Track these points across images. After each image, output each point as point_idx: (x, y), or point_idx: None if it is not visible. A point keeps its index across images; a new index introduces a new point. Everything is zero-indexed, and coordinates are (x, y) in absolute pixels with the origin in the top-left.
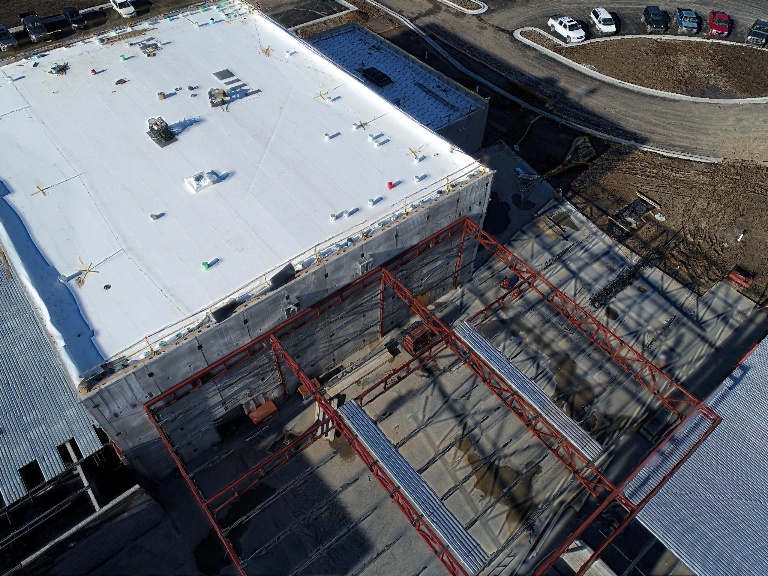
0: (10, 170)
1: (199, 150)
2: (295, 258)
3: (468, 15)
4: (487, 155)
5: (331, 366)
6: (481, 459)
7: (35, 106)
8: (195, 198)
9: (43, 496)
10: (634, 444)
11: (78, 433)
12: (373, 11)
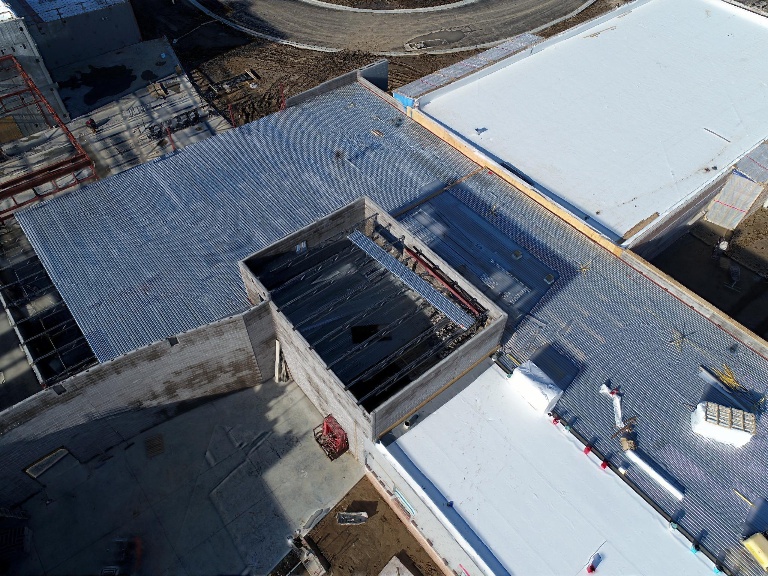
0: None
1: None
2: None
3: None
4: (145, 45)
5: None
6: None
7: None
8: None
9: None
10: None
11: None
12: None
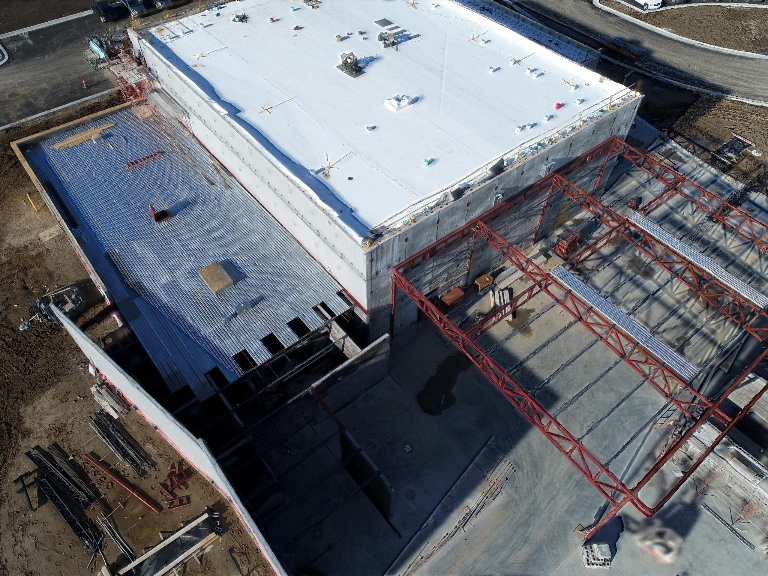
0: (233, 95)
1: (386, 80)
2: (507, 153)
3: None
4: None
5: (496, 266)
6: None
7: (232, 47)
8: (397, 115)
9: (300, 349)
10: (765, 325)
11: (326, 298)
12: None
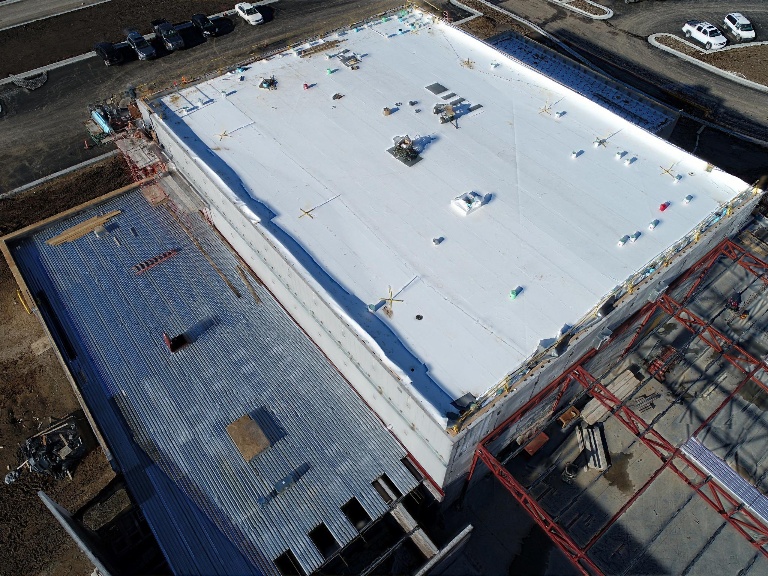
0: (265, 191)
1: (449, 169)
2: (620, 288)
3: (595, 20)
4: None
5: (579, 392)
6: (765, 492)
7: (260, 122)
8: (468, 221)
9: None
10: None
11: (388, 469)
12: (499, 17)
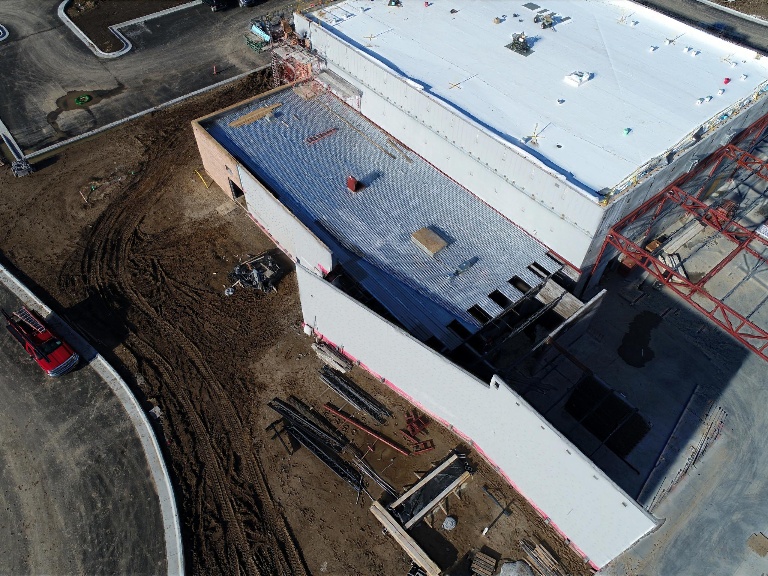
0: (418, 72)
1: (557, 58)
2: None
3: None
4: None
5: (658, 234)
6: None
7: (398, 29)
8: (580, 90)
9: None
10: None
11: (537, 259)
12: None
